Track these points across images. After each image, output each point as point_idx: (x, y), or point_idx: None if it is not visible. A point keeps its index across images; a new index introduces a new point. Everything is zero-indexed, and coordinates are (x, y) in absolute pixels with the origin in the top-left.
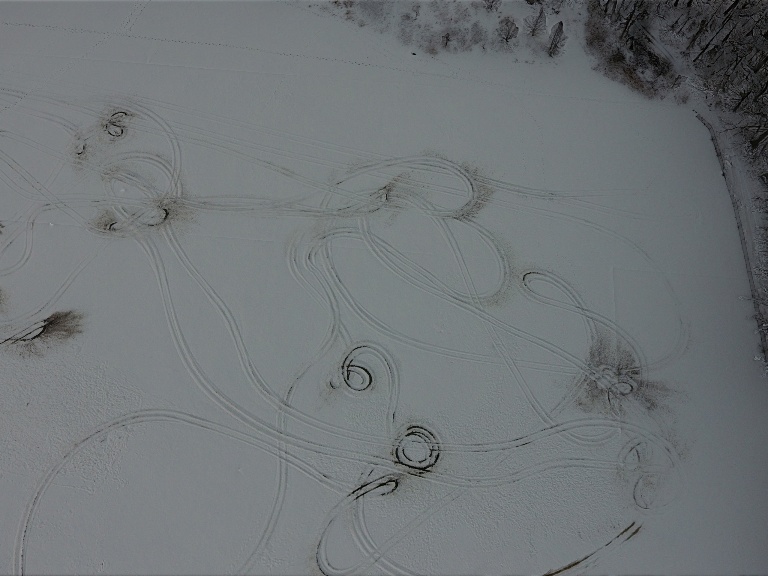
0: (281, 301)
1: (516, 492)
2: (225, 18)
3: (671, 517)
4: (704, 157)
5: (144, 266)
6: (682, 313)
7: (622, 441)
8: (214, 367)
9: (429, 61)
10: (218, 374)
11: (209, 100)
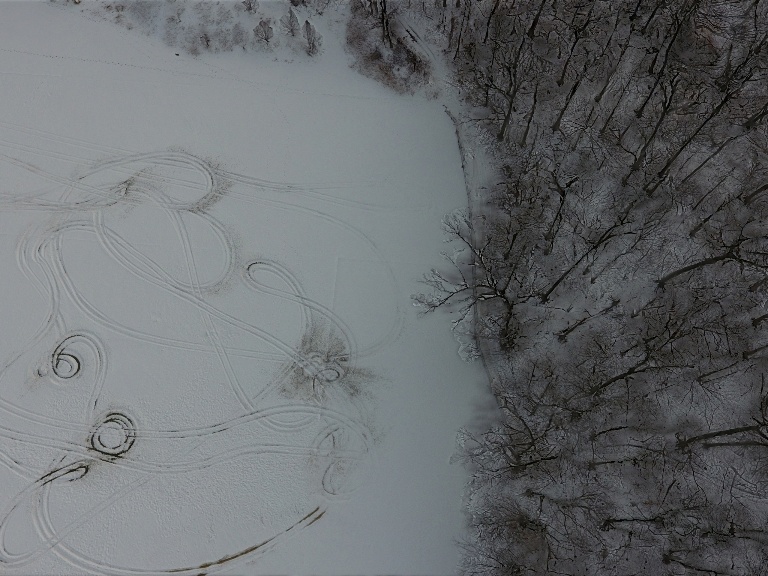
0: (3, 292)
1: (205, 478)
2: None
3: (356, 502)
4: (447, 150)
5: None
6: (400, 301)
7: (319, 427)
8: None
9: (190, 61)
10: None
11: None
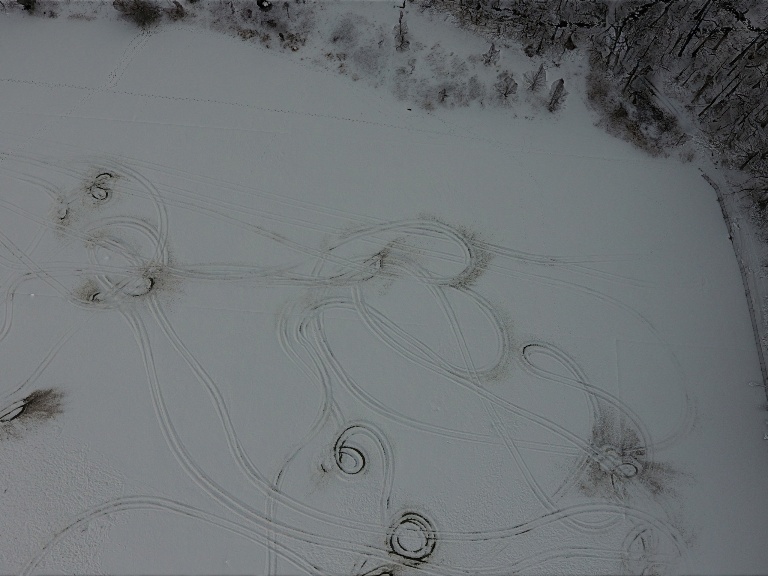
0: (271, 377)
1: None
2: (214, 72)
3: None
4: (710, 219)
5: (128, 340)
6: (688, 388)
7: (626, 528)
8: (201, 449)
9: (425, 117)
10: (205, 457)
11: (197, 160)
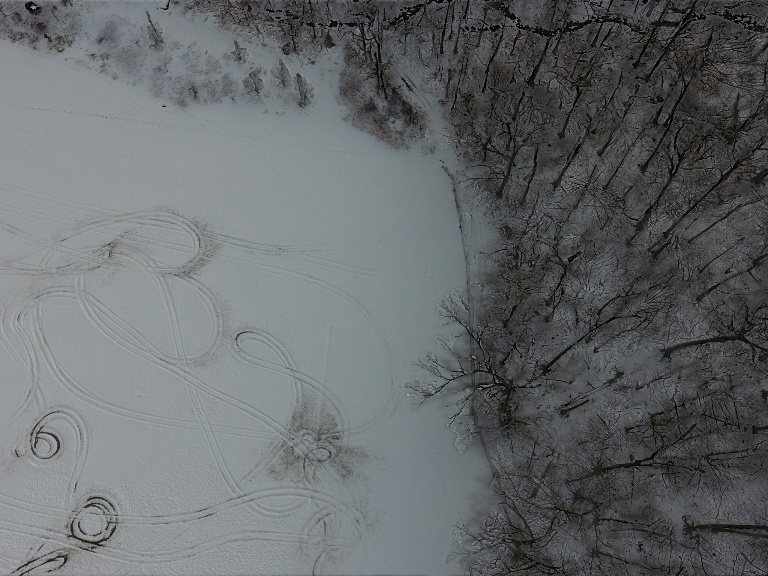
0: None
1: (189, 568)
2: None
3: None
4: (443, 209)
5: None
6: (395, 373)
7: (310, 512)
8: None
9: (178, 113)
10: None
11: None
